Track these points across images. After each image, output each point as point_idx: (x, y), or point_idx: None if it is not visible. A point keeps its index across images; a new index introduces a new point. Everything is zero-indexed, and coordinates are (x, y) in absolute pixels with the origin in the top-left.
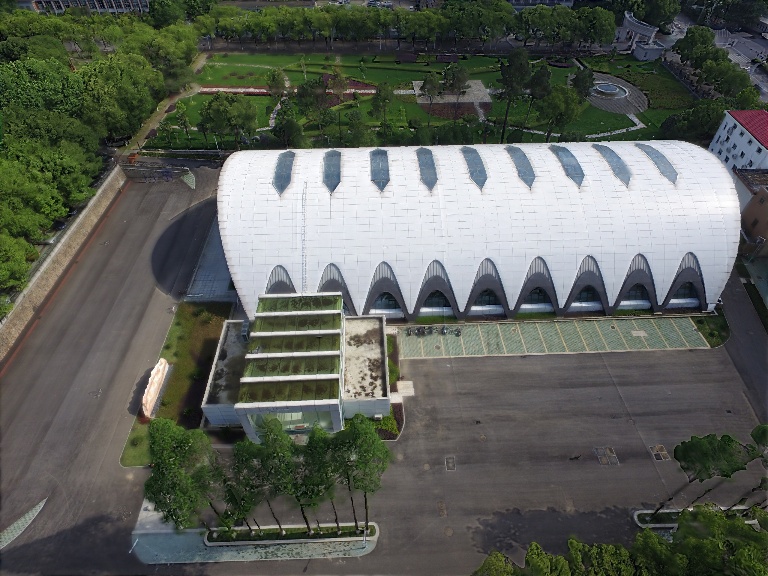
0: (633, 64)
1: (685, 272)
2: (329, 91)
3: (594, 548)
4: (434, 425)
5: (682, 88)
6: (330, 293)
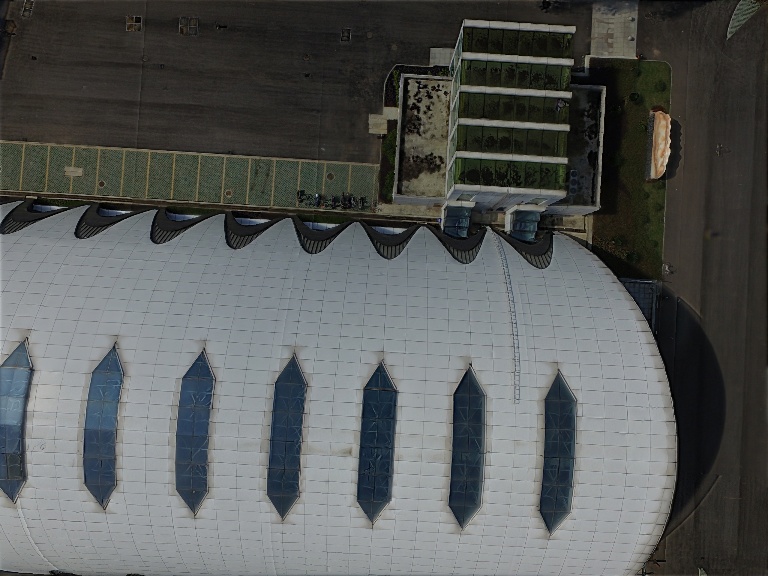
0: None
1: None
2: None
3: None
4: (354, 77)
5: None
6: (470, 188)
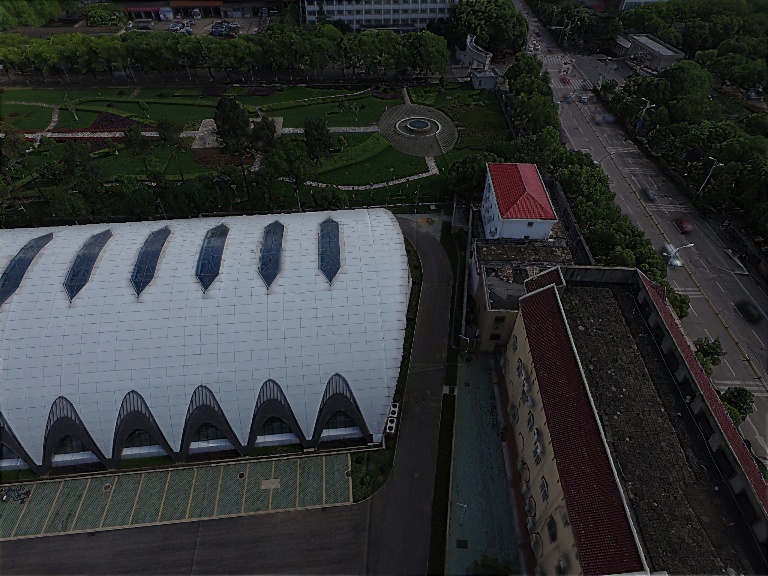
0: (465, 94)
1: (333, 399)
2: (95, 135)
3: None
4: None
5: (501, 123)
6: None
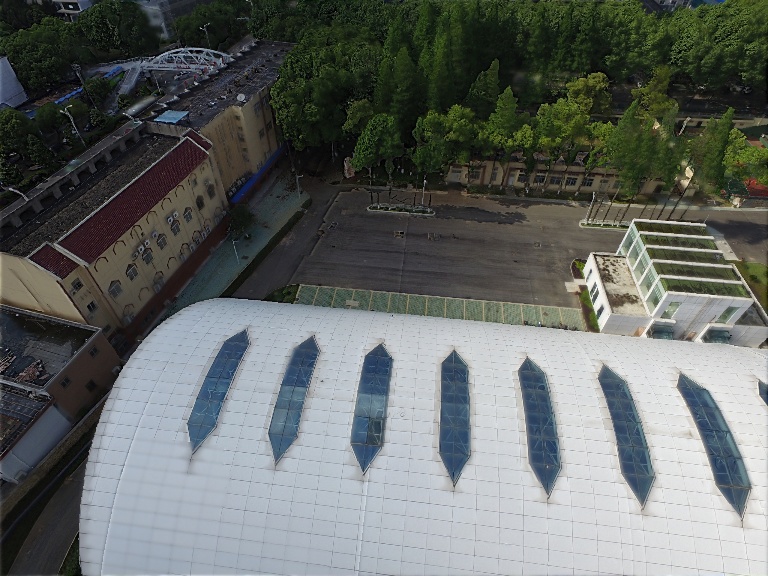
0: None
1: None
2: None
3: (503, 141)
4: (549, 263)
5: None
6: (680, 293)
